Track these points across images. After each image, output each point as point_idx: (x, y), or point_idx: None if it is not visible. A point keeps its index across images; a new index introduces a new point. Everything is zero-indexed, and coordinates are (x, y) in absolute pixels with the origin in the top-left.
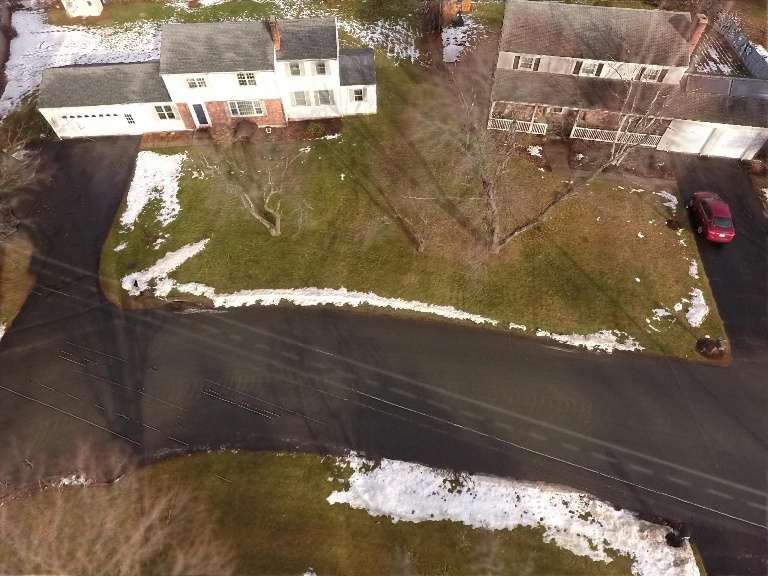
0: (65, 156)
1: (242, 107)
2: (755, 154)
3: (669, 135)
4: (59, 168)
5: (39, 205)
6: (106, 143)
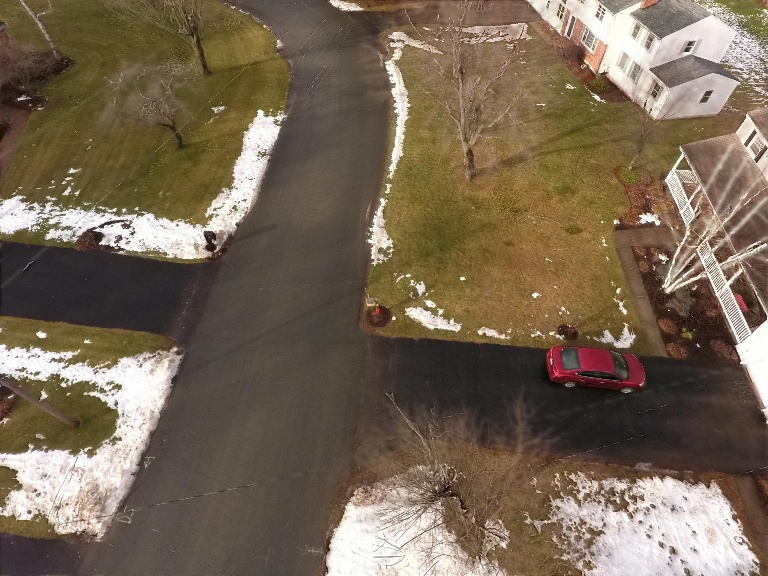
0: (506, 2)
1: (589, 37)
2: None
3: (756, 340)
4: (494, 3)
5: (457, 4)
6: (528, 12)
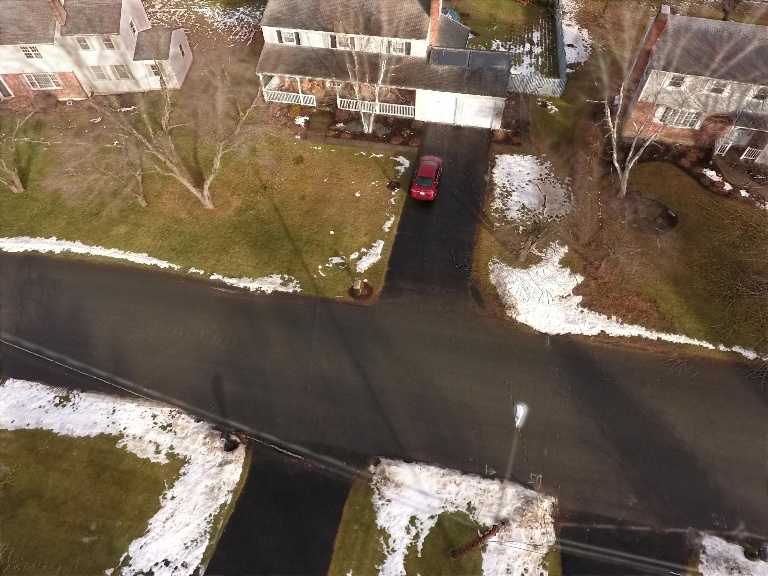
0: None
1: (39, 80)
2: (508, 124)
3: (420, 105)
4: None
5: None
6: None
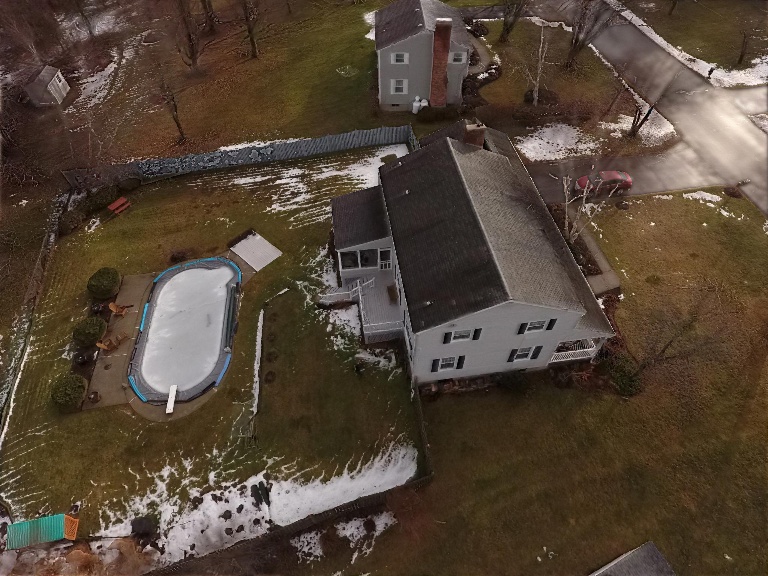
0: None
1: None
2: None
3: None
4: None
5: None
6: None
